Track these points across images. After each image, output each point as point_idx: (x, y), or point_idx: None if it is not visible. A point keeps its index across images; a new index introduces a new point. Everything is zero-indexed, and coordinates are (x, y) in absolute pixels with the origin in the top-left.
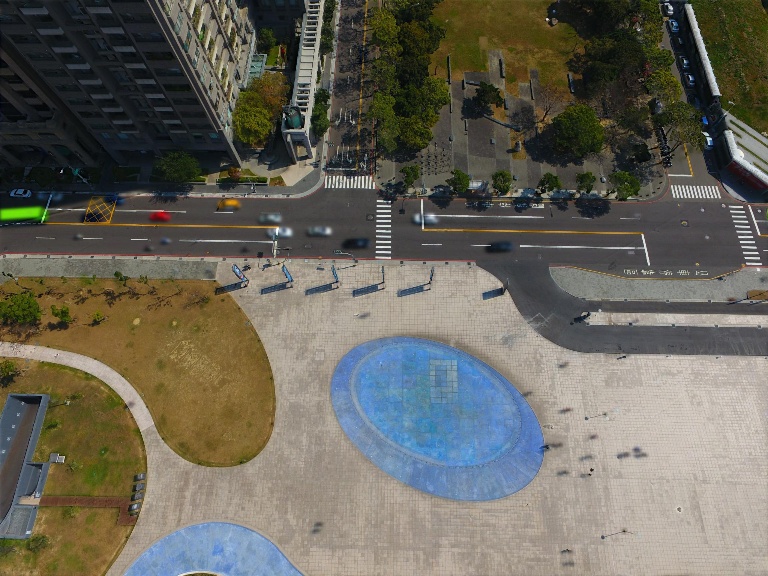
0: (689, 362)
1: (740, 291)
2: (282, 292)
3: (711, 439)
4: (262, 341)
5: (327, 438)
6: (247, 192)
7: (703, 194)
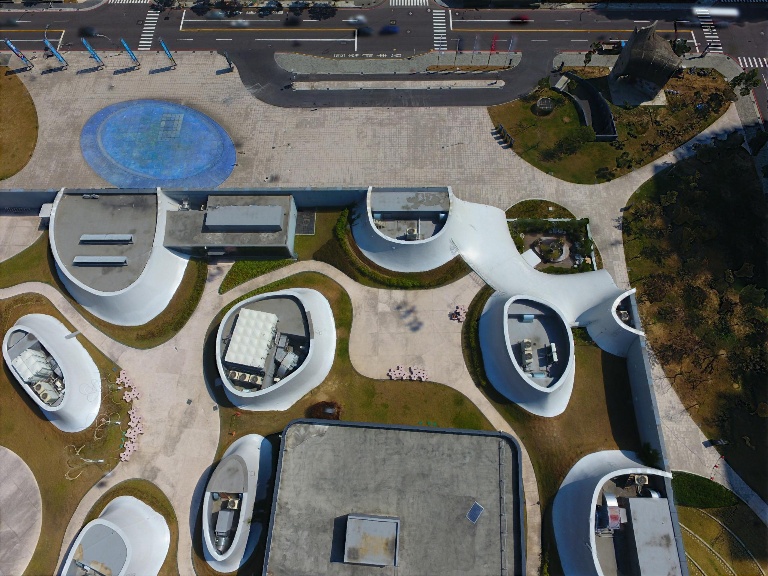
0: (365, 112)
1: (422, 66)
2: (58, 73)
3: (365, 158)
4: (35, 104)
5: (71, 163)
6: (45, 7)
7: (414, 3)
